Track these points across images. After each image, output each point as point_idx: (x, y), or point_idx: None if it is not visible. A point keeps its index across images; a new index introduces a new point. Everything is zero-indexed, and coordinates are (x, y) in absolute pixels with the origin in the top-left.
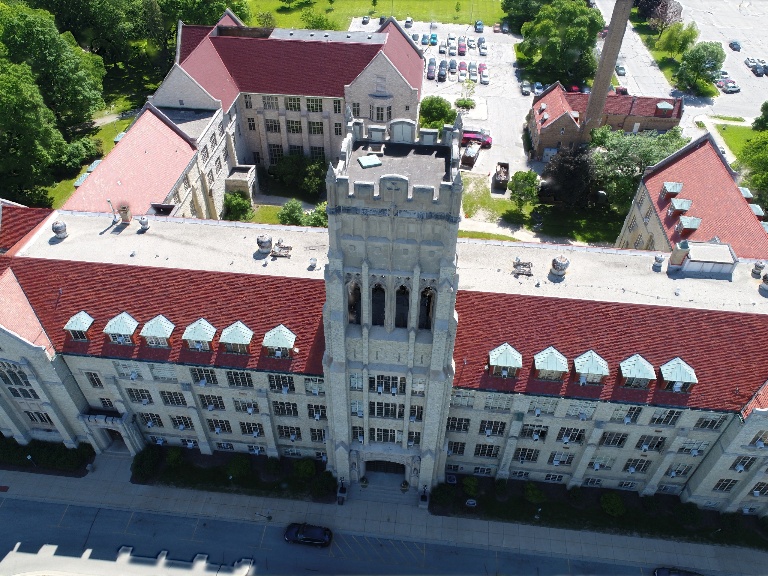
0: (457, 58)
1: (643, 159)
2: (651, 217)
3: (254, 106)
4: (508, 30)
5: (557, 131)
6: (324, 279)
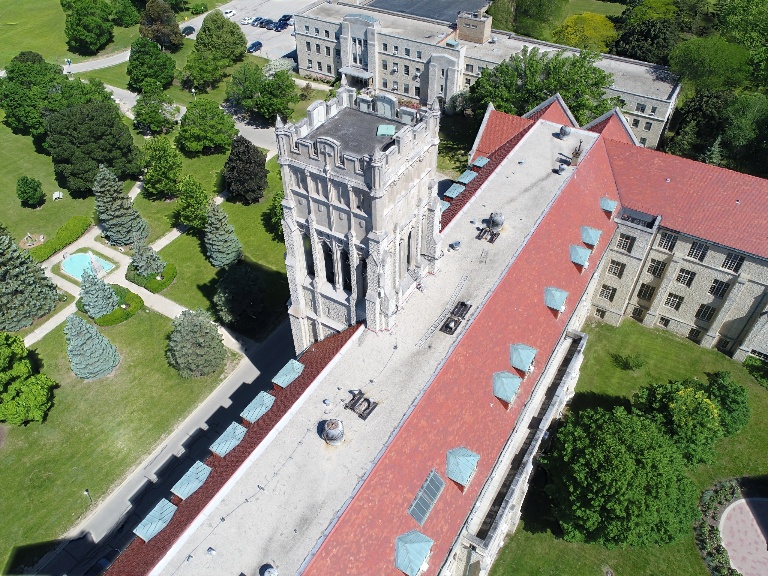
0: None
1: None
2: None
3: None
4: None
5: None
6: None
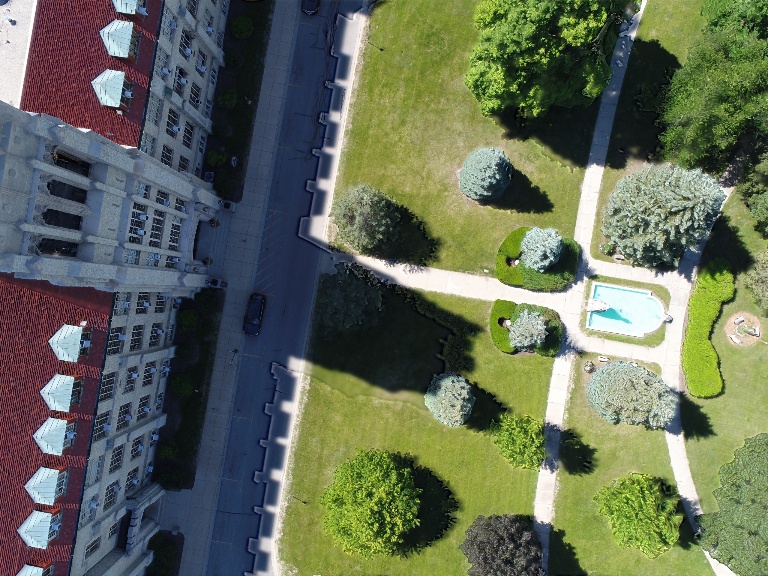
0: None
1: None
2: None
3: None
4: None
5: None
6: None
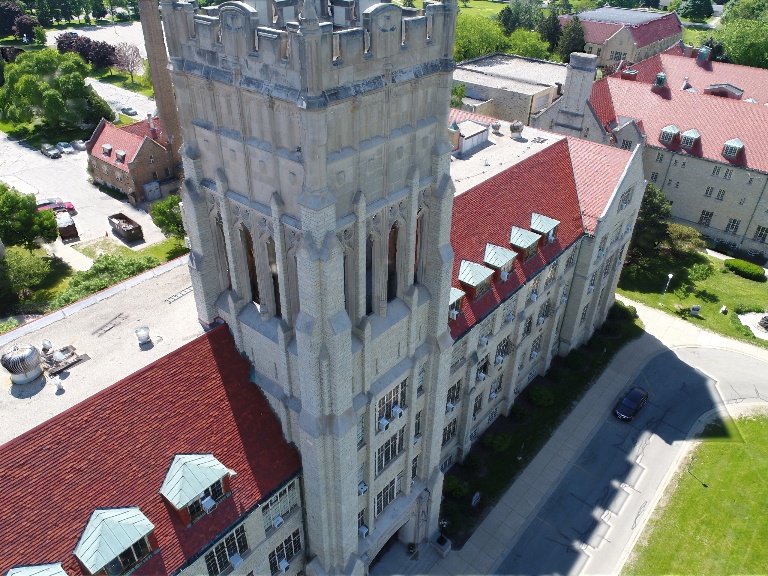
0: None
1: None
2: None
3: None
4: None
5: (146, 161)
6: (191, 340)
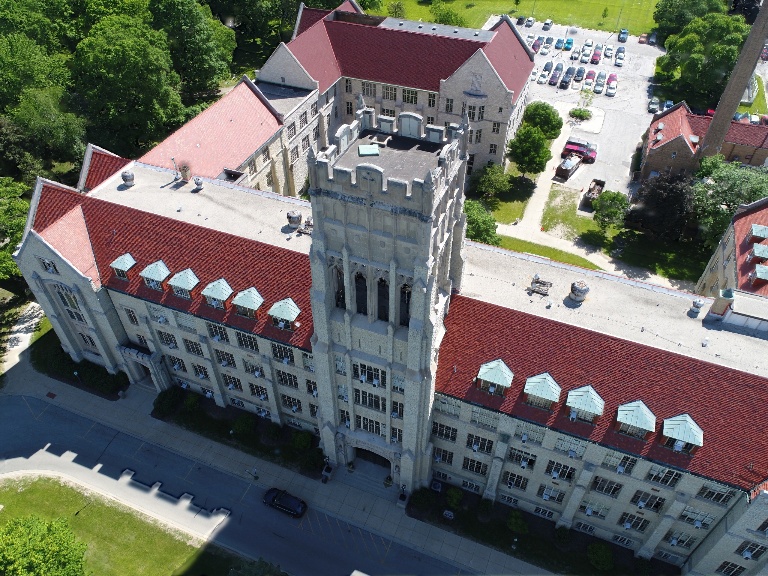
0: (588, 66)
1: (751, 197)
2: (730, 260)
3: (353, 91)
4: (655, 42)
5: (668, 154)
6: None
